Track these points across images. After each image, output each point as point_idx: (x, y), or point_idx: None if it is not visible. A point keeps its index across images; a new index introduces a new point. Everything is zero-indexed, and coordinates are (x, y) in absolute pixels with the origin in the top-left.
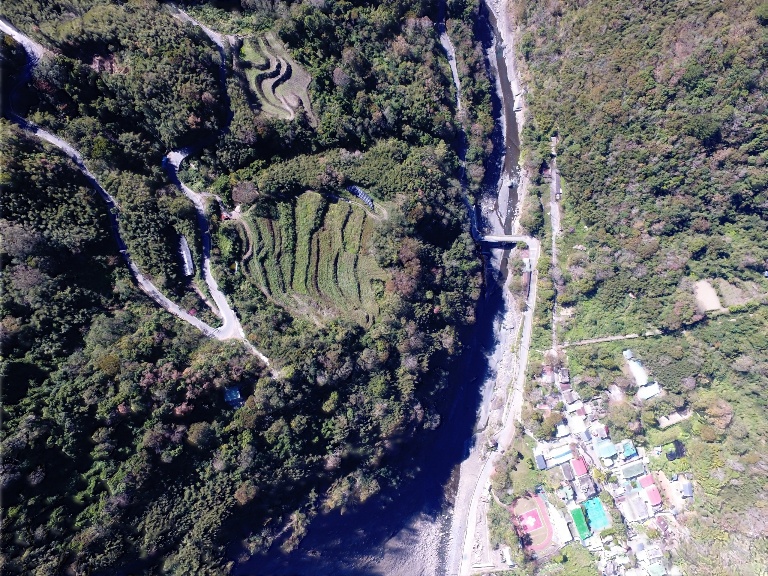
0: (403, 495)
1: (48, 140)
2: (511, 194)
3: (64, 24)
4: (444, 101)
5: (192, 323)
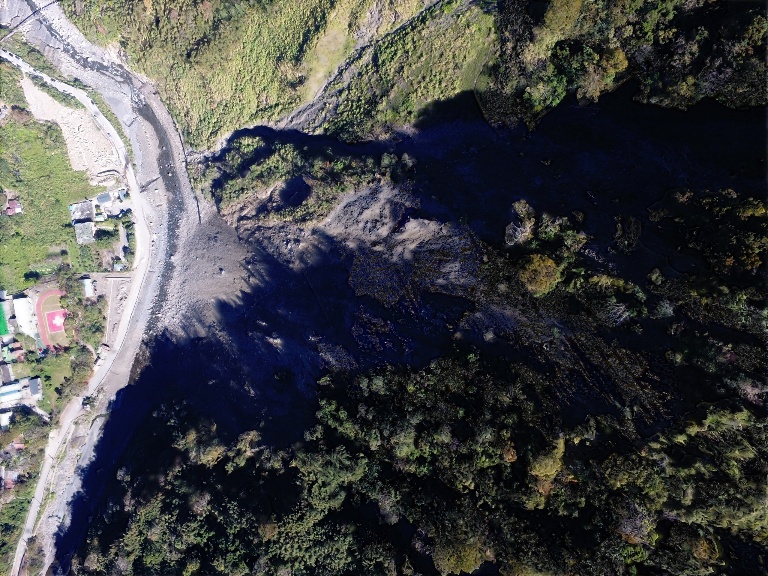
0: (185, 375)
1: None
2: None
3: None
4: None
5: None
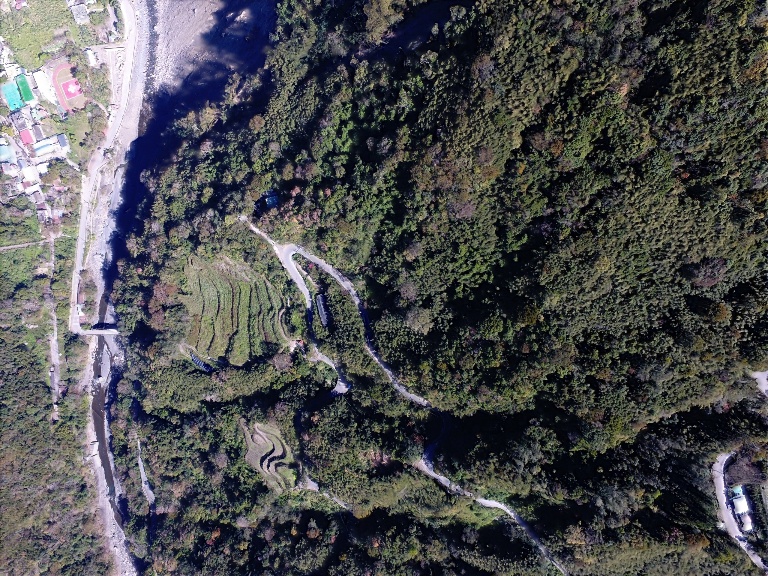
0: None
1: (418, 397)
2: (99, 371)
3: (403, 486)
4: (146, 446)
5: (315, 257)
